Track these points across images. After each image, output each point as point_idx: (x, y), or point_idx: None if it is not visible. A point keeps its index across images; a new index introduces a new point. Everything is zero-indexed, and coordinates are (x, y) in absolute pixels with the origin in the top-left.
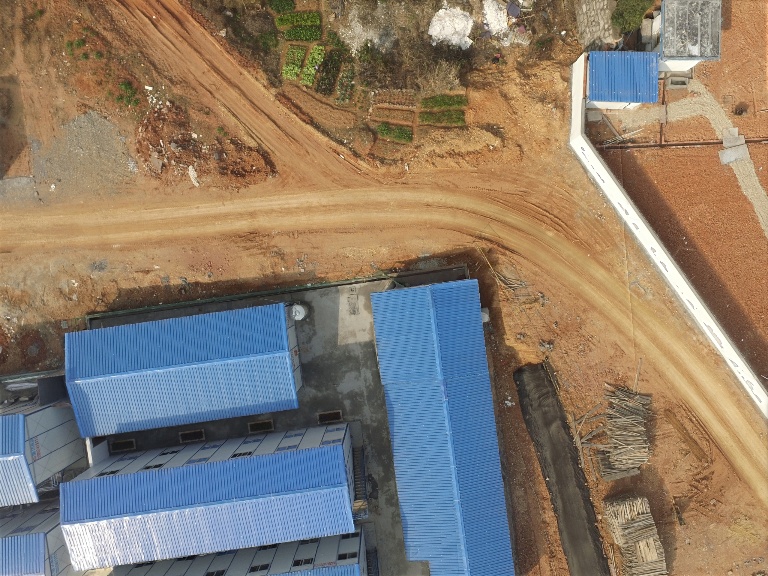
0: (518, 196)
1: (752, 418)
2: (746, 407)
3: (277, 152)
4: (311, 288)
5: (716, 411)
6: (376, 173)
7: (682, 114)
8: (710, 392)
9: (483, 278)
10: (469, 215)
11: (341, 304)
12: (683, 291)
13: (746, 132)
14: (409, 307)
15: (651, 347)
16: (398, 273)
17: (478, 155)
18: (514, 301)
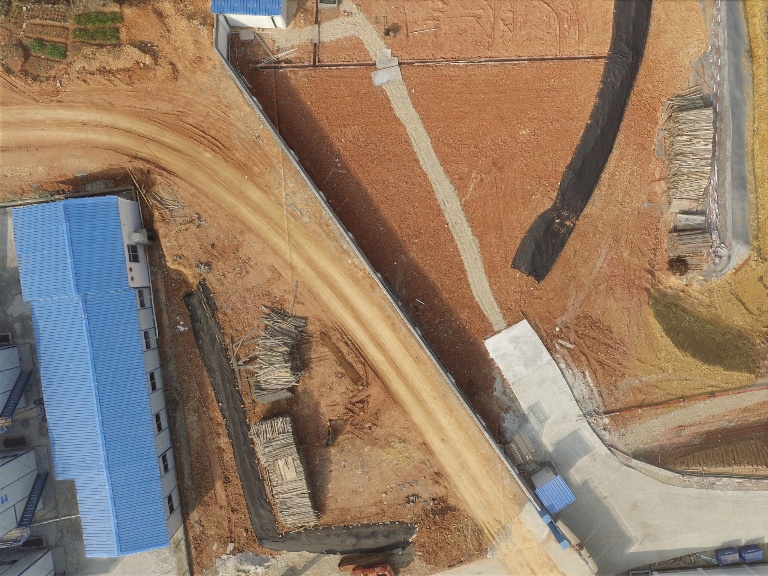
0: (174, 116)
1: (407, 342)
2: (401, 331)
3: None
4: None
5: (372, 334)
6: (31, 91)
7: (335, 34)
8: (365, 315)
9: None
10: (125, 134)
11: (10, 226)
12: None
13: (400, 54)
14: (45, 222)
15: (307, 270)
16: (64, 195)
17: (129, 73)
18: (171, 222)
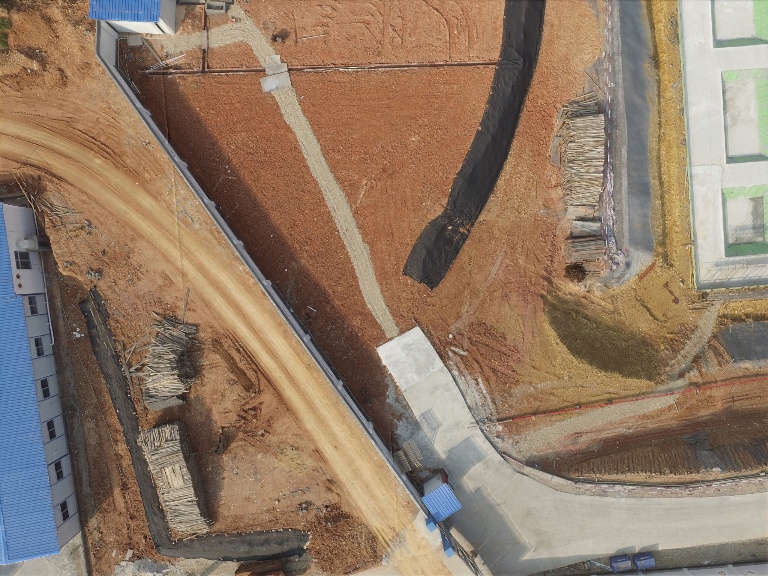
0: (64, 122)
1: (299, 349)
2: (293, 338)
3: None
4: None
5: (264, 342)
6: None
7: (223, 40)
8: (257, 322)
9: None
10: (14, 141)
11: None
12: None
13: (289, 60)
14: None
15: (198, 277)
16: None
17: (17, 79)
18: (61, 229)
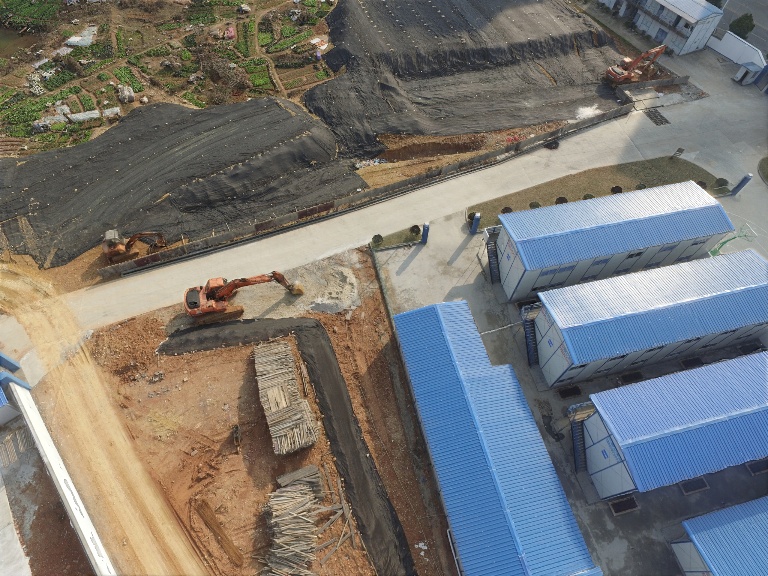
0: None
1: (133, 567)
2: None
3: None
4: None
5: (177, 571)
6: None
7: None
8: None
9: None
10: None
11: None
12: None
13: None
14: None
15: None
16: None
17: None
18: None
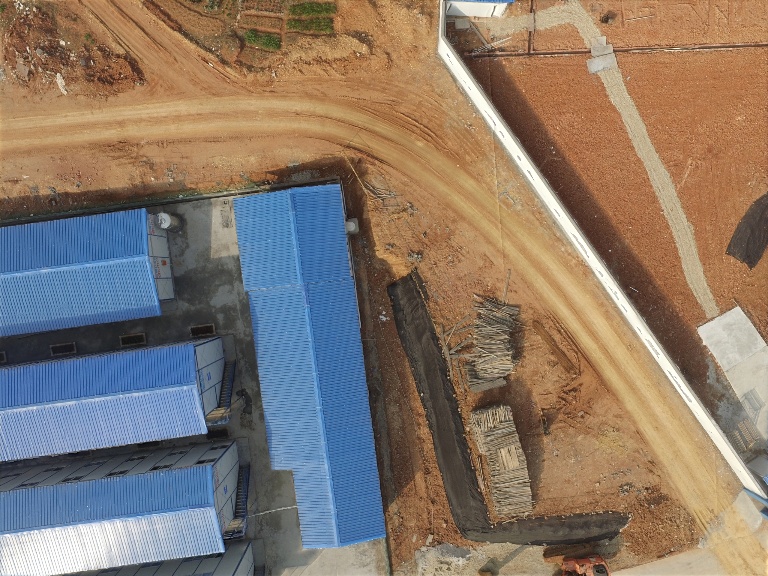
0: (387, 105)
1: (620, 330)
2: (614, 318)
3: (145, 60)
4: (183, 200)
5: (584, 323)
6: (244, 81)
7: (550, 22)
8: (578, 303)
9: (355, 190)
10: (338, 124)
11: (214, 217)
12: (548, 199)
13: (614, 41)
14: (270, 211)
15: (520, 258)
16: (270, 185)
17: (345, 62)
18: (383, 211)
